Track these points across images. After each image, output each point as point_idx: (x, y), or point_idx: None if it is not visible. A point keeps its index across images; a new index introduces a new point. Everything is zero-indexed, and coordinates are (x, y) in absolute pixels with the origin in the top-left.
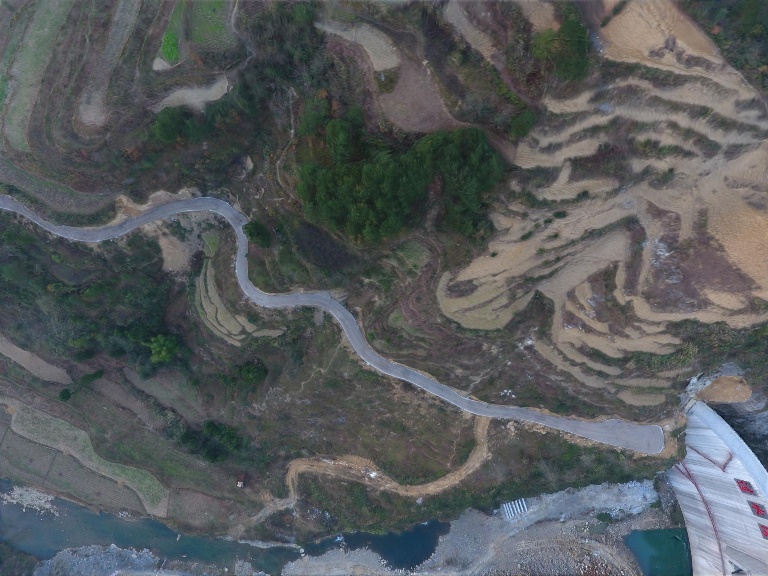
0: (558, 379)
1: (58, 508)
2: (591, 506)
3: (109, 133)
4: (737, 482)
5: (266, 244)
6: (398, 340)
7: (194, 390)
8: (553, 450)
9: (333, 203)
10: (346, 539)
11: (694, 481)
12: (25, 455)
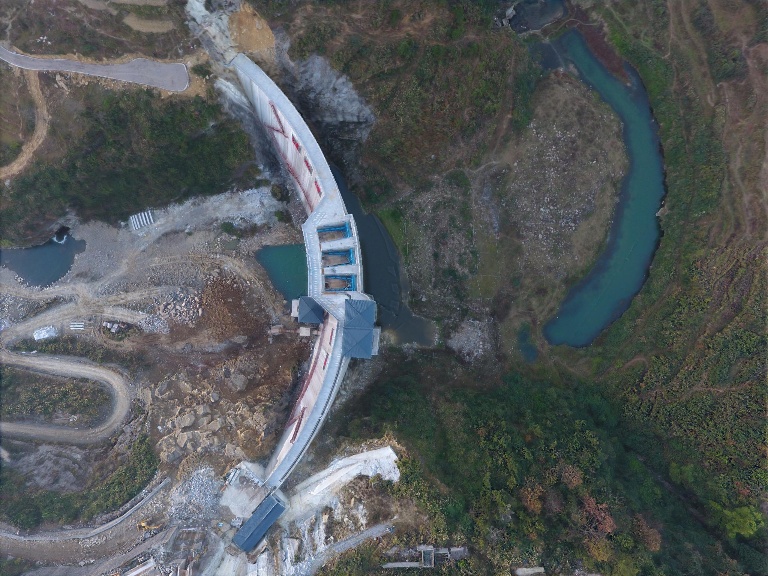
0: (72, 10)
1: None
2: (215, 216)
3: None
4: None
5: None
6: None
7: None
8: (96, 100)
9: None
10: None
11: (295, 176)
12: None
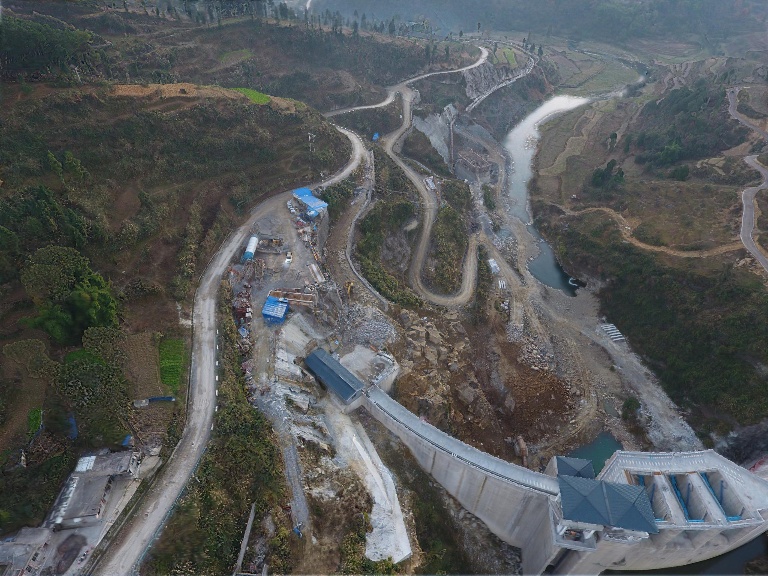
0: None
1: (530, 149)
2: (641, 392)
3: None
4: None
5: None
6: None
7: None
8: (745, 279)
9: None
10: (544, 243)
11: None
12: (558, 140)
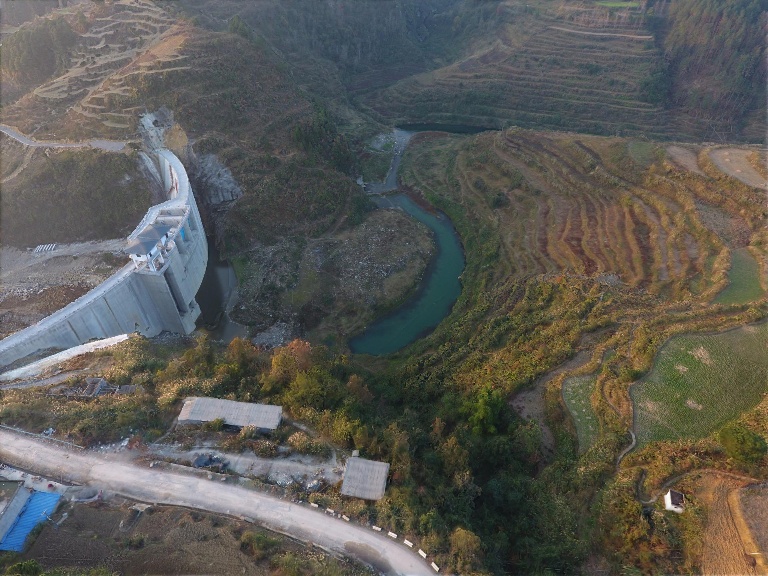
0: (78, 120)
1: None
2: (102, 249)
3: None
4: None
5: None
6: (8, 111)
7: None
8: None
9: (5, 50)
10: None
11: None
12: None
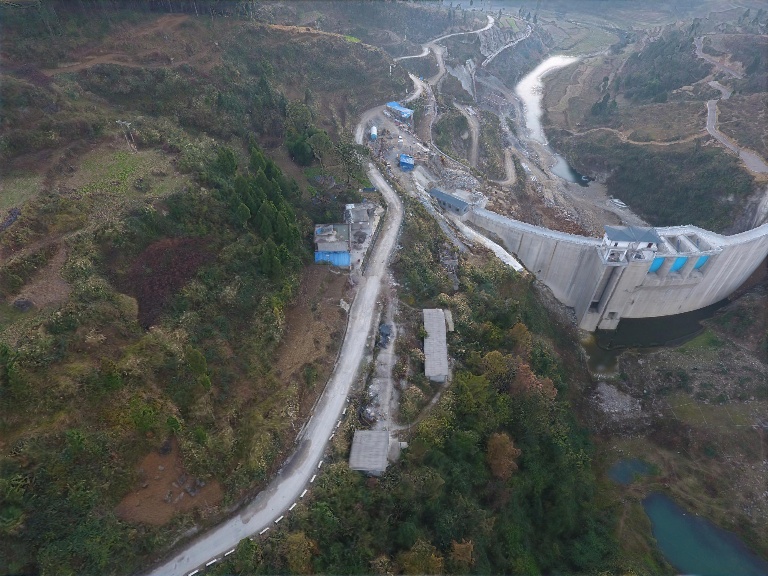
0: None
1: (537, 95)
2: None
3: (763, 39)
4: None
5: (749, 70)
6: None
7: None
8: None
9: None
10: (559, 156)
11: None
12: (559, 87)
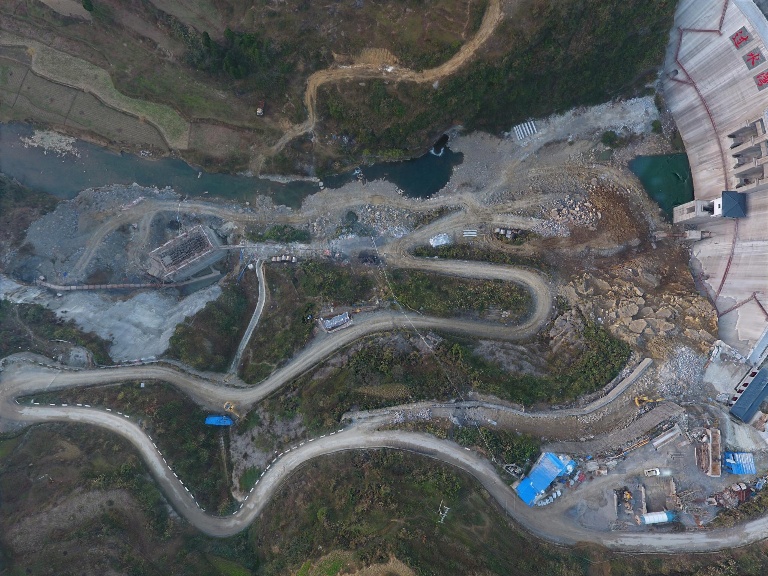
0: None
1: (79, 150)
2: (597, 126)
3: None
4: (733, 40)
5: None
6: None
7: (213, 8)
8: None
9: None
10: (364, 172)
11: (692, 81)
12: (46, 95)
